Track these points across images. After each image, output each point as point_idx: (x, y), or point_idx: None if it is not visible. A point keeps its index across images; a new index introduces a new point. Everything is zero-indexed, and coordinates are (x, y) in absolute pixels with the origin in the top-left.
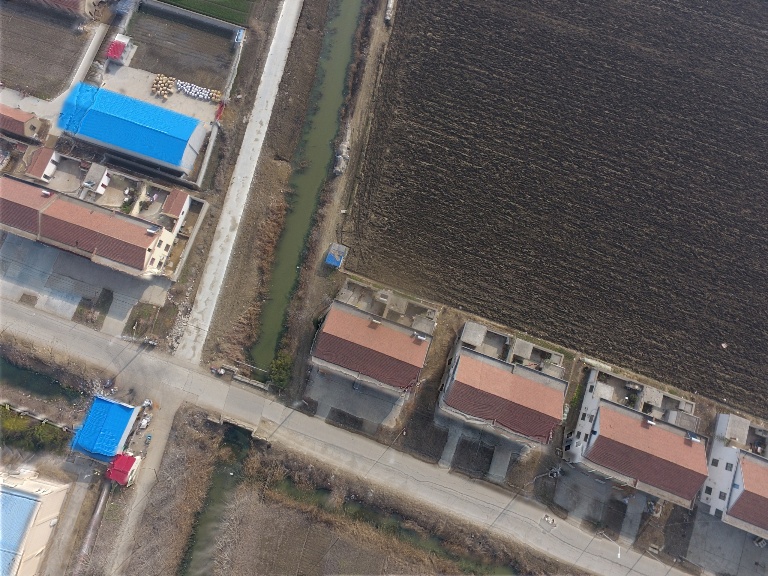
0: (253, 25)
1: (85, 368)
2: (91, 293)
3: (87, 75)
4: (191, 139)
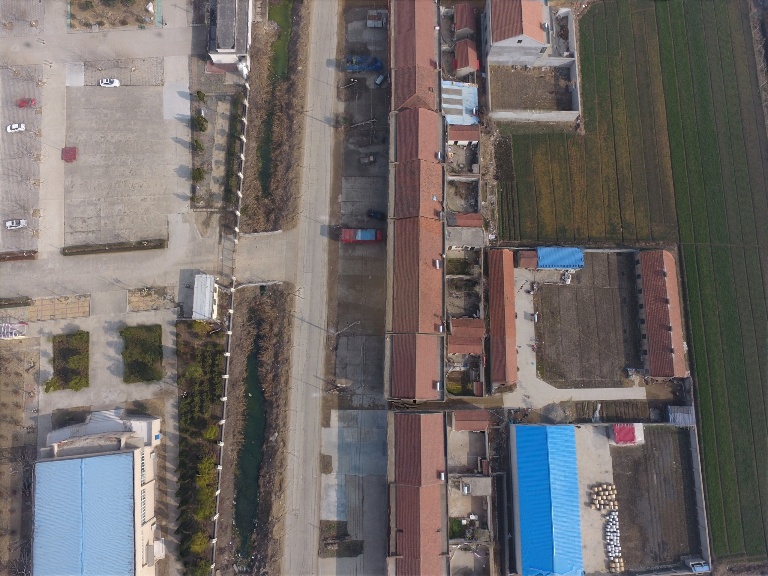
0: (718, 568)
1: (278, 560)
2: (354, 529)
3: (581, 401)
4: (558, 574)
